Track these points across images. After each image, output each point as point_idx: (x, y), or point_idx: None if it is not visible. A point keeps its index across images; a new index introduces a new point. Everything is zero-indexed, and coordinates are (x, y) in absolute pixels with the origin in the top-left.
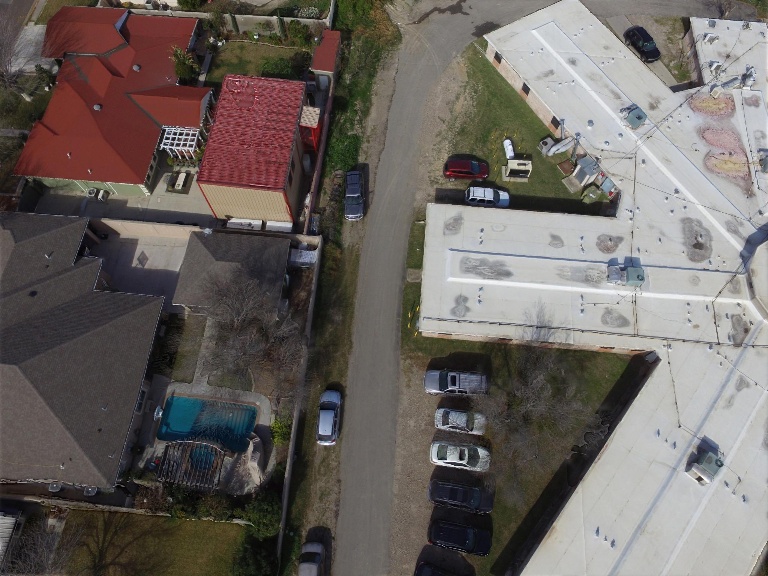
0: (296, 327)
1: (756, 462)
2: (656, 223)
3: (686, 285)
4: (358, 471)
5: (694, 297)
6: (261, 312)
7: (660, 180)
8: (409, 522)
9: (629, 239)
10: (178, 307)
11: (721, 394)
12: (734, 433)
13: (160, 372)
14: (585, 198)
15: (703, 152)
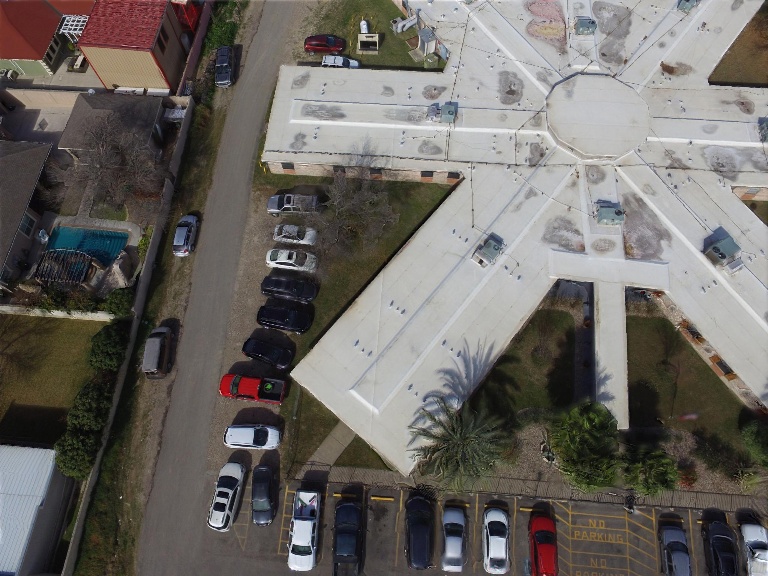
0: (147, 147)
1: (534, 252)
2: (476, 76)
3: (494, 121)
4: (206, 275)
5: (500, 130)
6: (119, 137)
7: (485, 43)
8: (245, 311)
9: (451, 88)
10: (68, 158)
11: (511, 201)
12: (518, 230)
13: (50, 209)
14: (424, 63)
15: (527, 21)
